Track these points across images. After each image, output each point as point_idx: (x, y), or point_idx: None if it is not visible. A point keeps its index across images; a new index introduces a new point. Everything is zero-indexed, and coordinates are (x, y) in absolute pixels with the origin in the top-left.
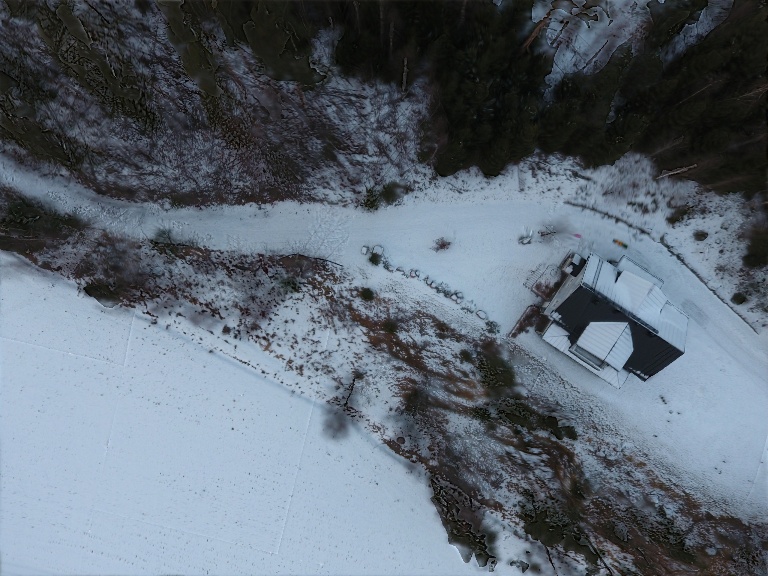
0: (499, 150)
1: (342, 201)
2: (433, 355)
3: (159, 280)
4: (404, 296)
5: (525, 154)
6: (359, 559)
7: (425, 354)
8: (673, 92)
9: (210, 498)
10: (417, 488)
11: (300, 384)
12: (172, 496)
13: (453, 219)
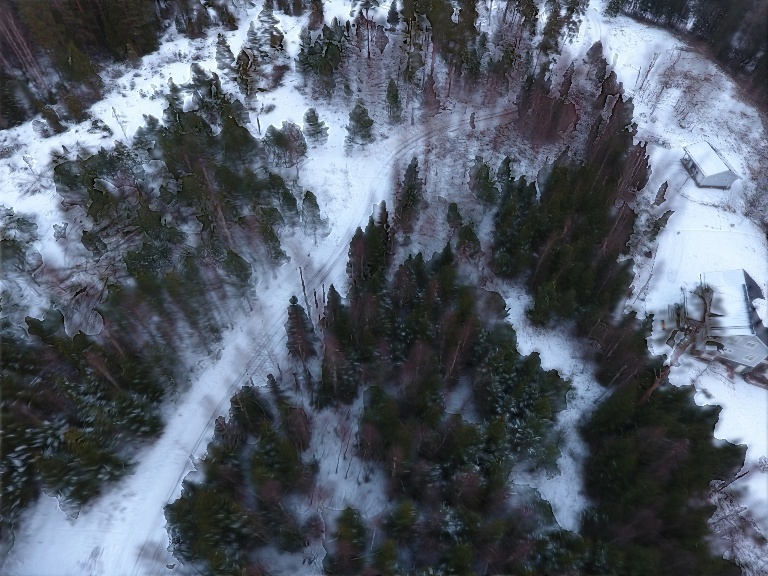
0: None
1: None
2: None
3: None
4: None
5: None
6: None
7: None
8: None
9: None
10: None
11: None
12: None
13: None
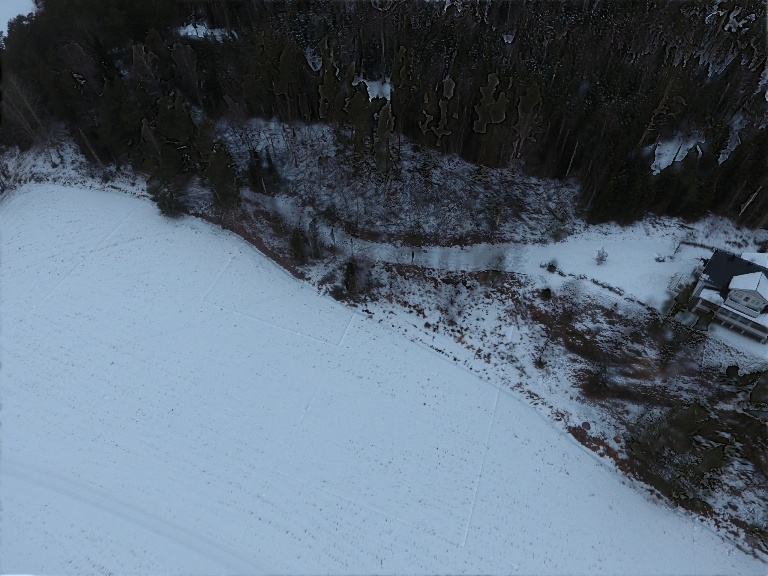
0: (636, 186)
1: (523, 240)
2: (606, 339)
3: (381, 289)
4: (577, 292)
5: (649, 201)
6: (559, 564)
7: (599, 339)
8: (729, 171)
9: (395, 471)
10: (611, 483)
11: (487, 370)
12: (357, 465)
13: (604, 249)
